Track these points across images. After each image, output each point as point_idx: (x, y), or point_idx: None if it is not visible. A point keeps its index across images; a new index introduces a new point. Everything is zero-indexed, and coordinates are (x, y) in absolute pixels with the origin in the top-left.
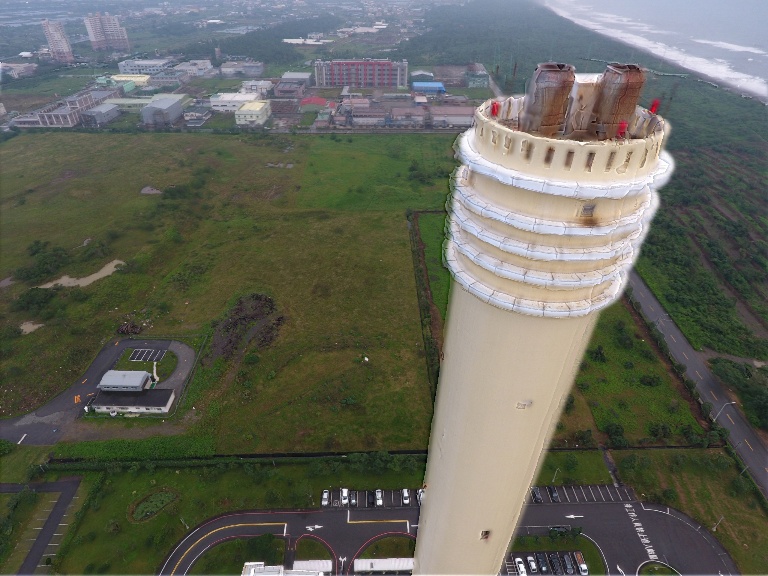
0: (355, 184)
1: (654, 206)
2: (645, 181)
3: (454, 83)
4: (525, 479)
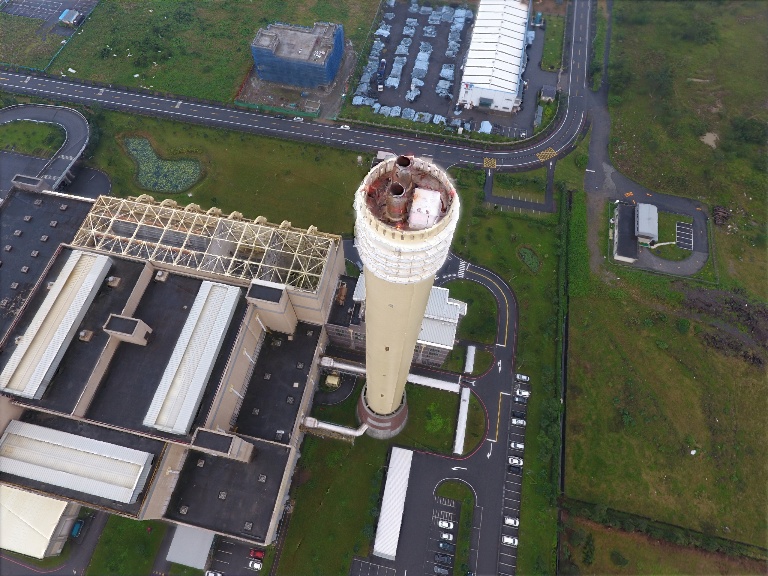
0: None
1: None
2: None
3: None
4: None
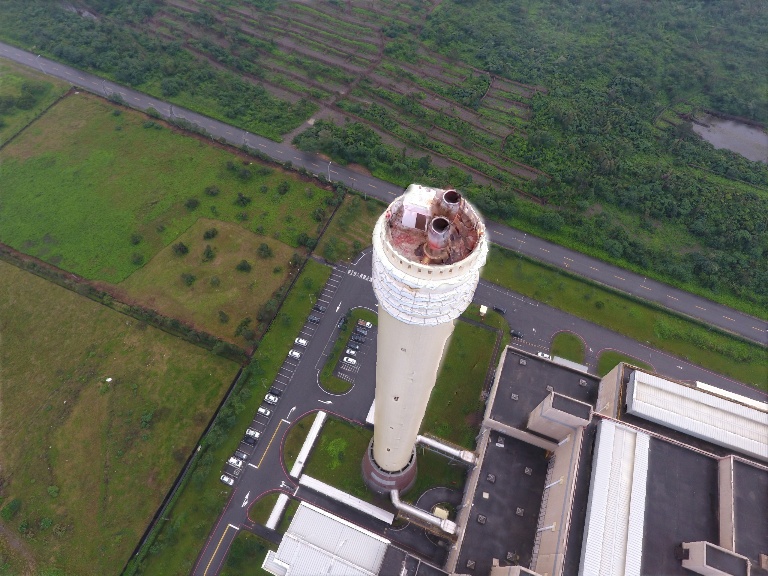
0: None
1: (133, 34)
2: None
3: None
4: None
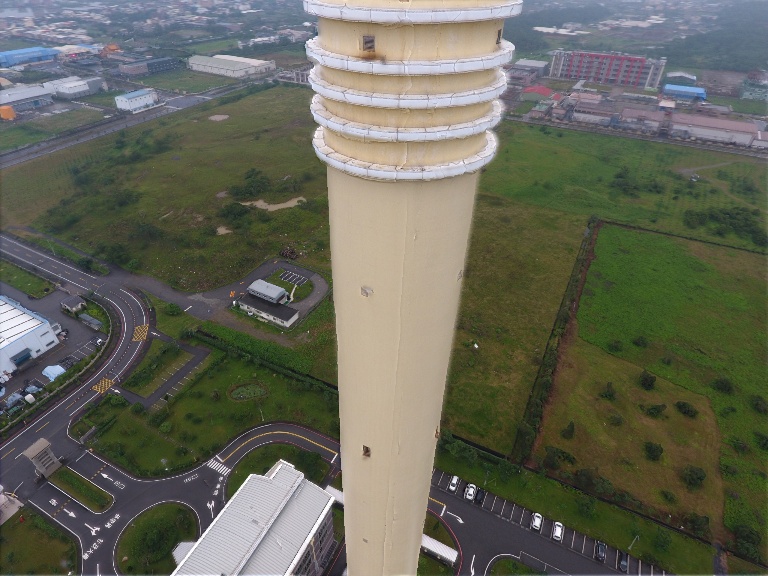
0: (545, 179)
1: None
2: (439, 17)
3: (722, 91)
4: (399, 400)
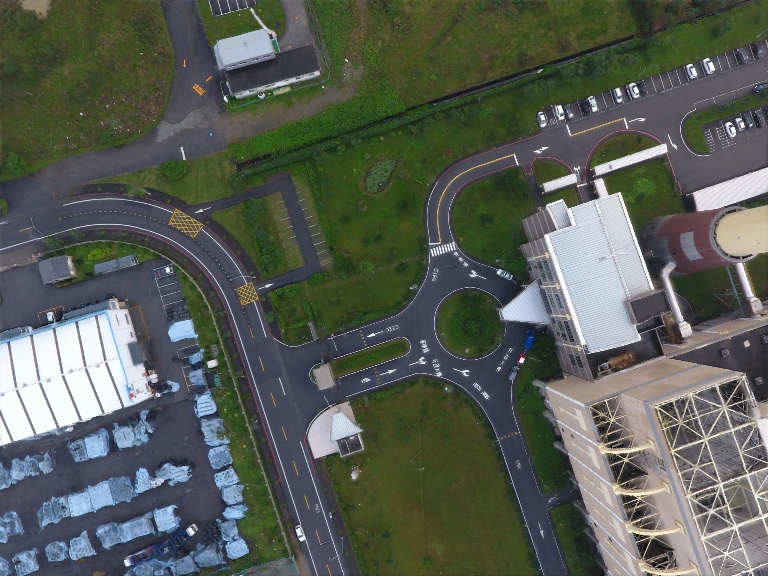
0: None
1: None
2: None
3: None
4: None
